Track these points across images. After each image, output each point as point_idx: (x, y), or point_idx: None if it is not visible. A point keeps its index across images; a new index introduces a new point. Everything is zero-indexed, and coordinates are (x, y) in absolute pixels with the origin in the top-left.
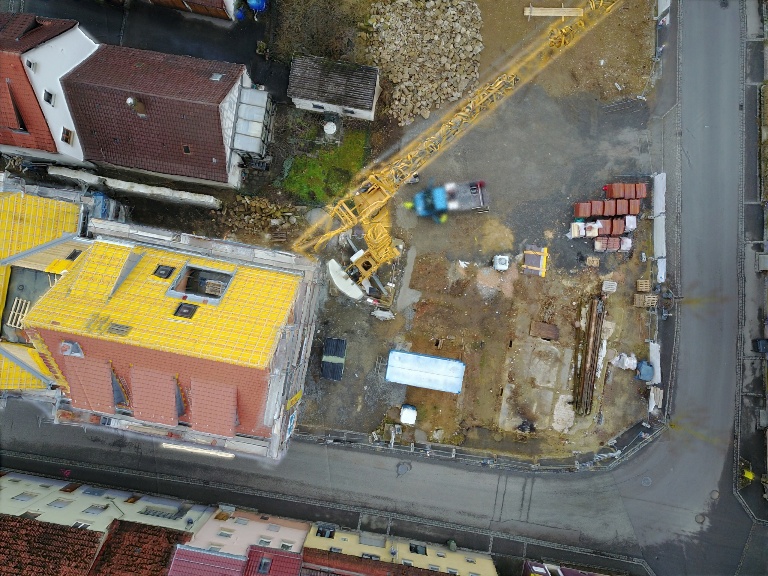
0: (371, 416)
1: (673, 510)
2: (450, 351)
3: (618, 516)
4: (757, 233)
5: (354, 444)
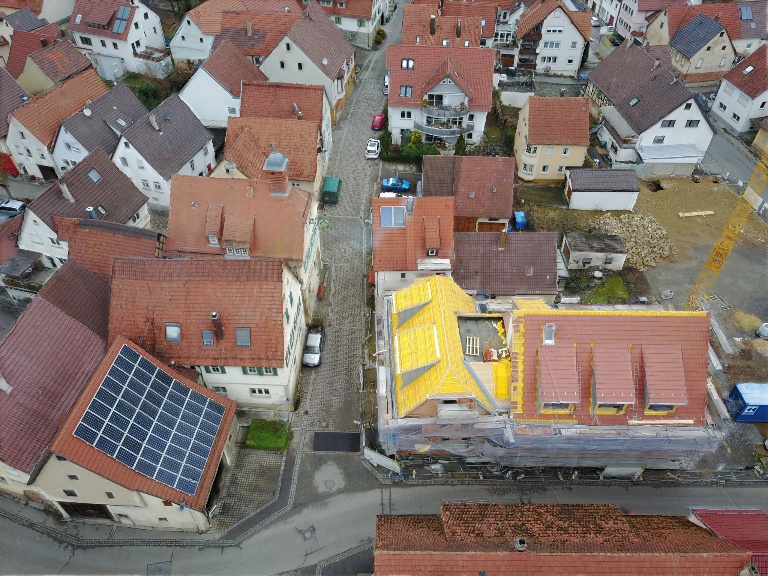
0: (743, 455)
1: None
2: None
3: None
4: None
5: (745, 481)
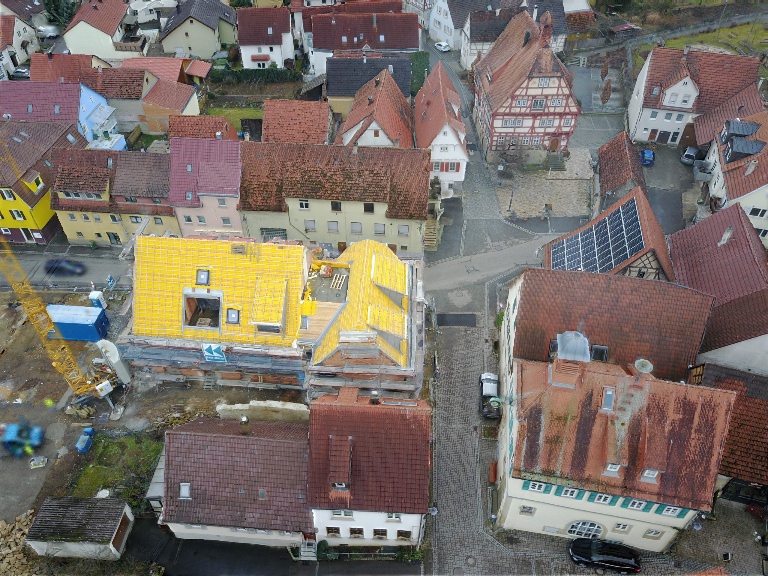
0: None
1: None
2: (55, 344)
3: None
4: None
5: None
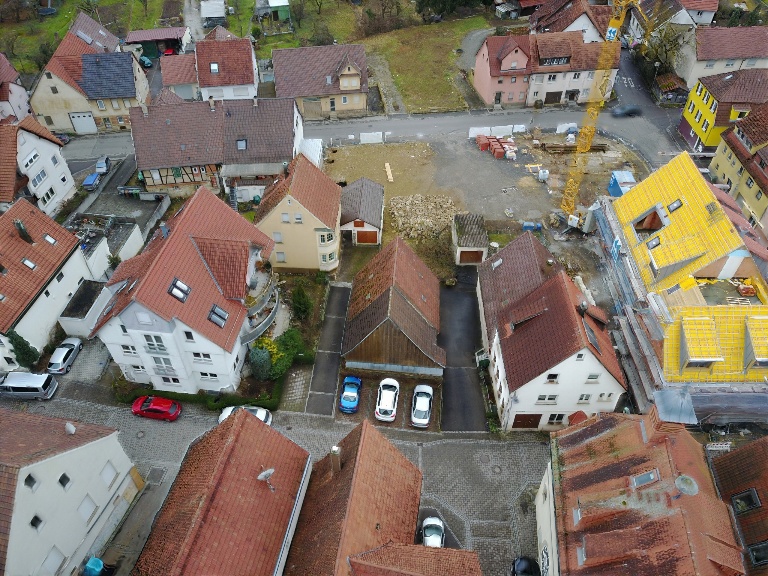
0: None
1: (634, 123)
2: (604, 193)
3: (651, 136)
4: (484, 111)
5: None
